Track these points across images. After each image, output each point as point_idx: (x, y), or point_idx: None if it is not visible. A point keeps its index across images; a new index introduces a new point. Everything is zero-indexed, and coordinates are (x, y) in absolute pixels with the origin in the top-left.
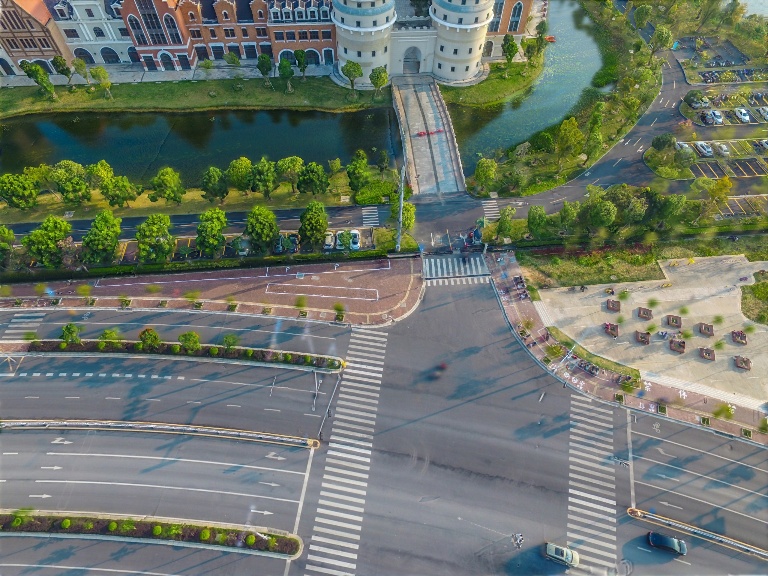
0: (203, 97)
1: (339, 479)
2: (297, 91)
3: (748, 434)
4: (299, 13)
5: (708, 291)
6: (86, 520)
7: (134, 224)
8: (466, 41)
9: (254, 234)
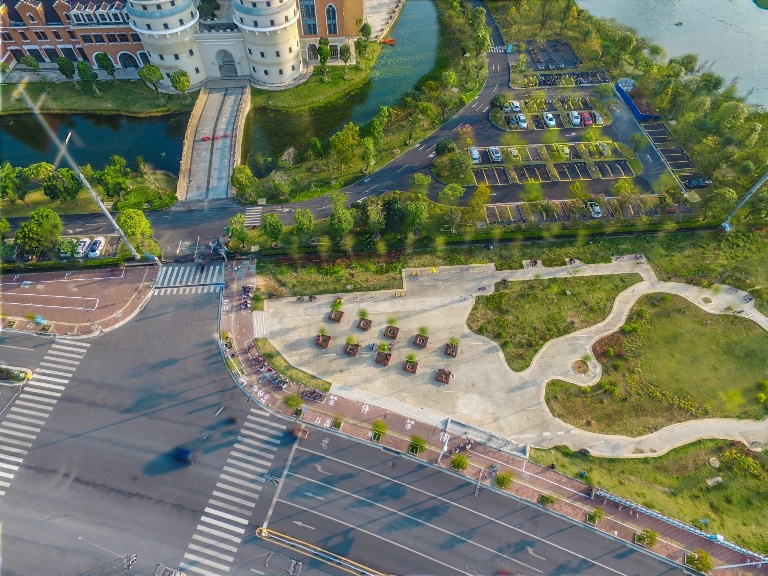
0: (8, 101)
1: None
2: (106, 94)
3: (415, 451)
4: (101, 16)
5: (441, 301)
6: None
7: None
8: (269, 44)
9: None
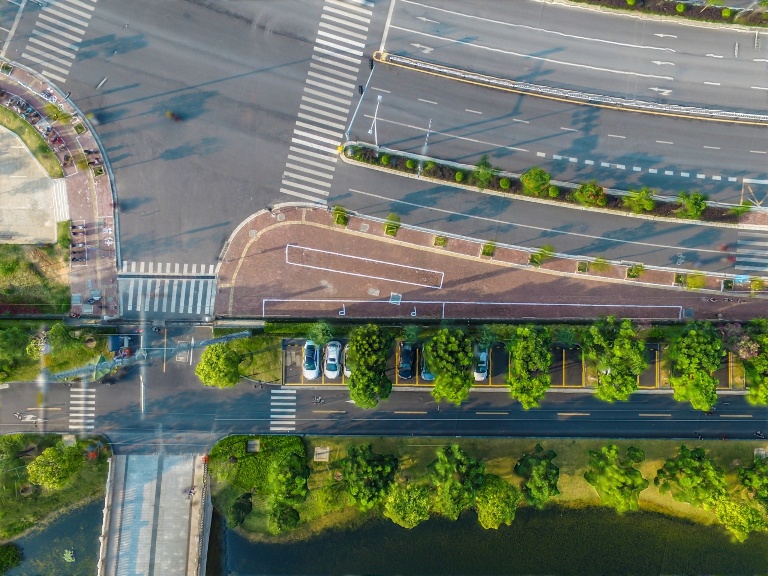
0: None
1: (353, 16)
2: None
3: None
4: None
5: None
6: (612, 3)
7: (655, 424)
8: None
9: (461, 335)
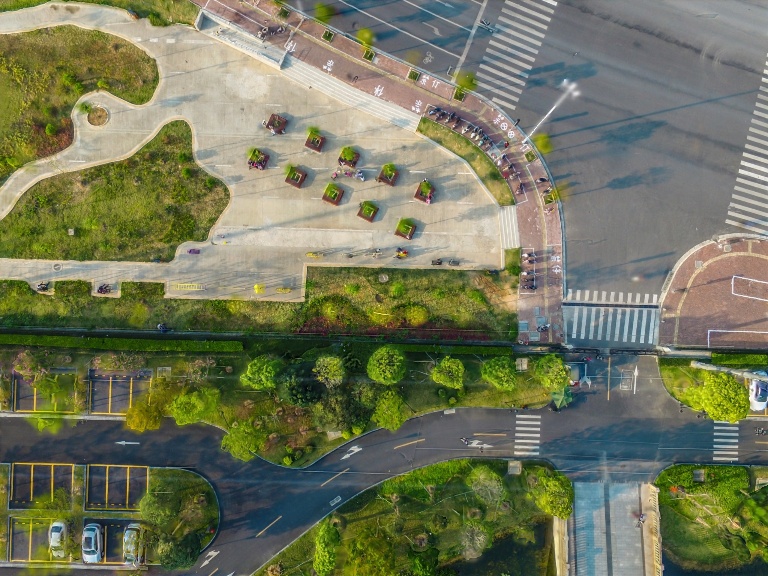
0: None
1: None
2: None
3: (328, 34)
4: None
5: (258, 238)
6: None
7: None
8: None
9: None
